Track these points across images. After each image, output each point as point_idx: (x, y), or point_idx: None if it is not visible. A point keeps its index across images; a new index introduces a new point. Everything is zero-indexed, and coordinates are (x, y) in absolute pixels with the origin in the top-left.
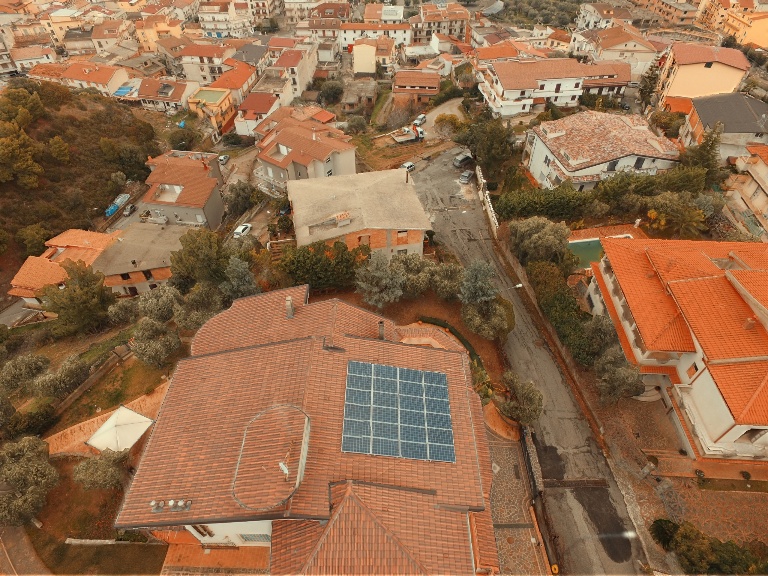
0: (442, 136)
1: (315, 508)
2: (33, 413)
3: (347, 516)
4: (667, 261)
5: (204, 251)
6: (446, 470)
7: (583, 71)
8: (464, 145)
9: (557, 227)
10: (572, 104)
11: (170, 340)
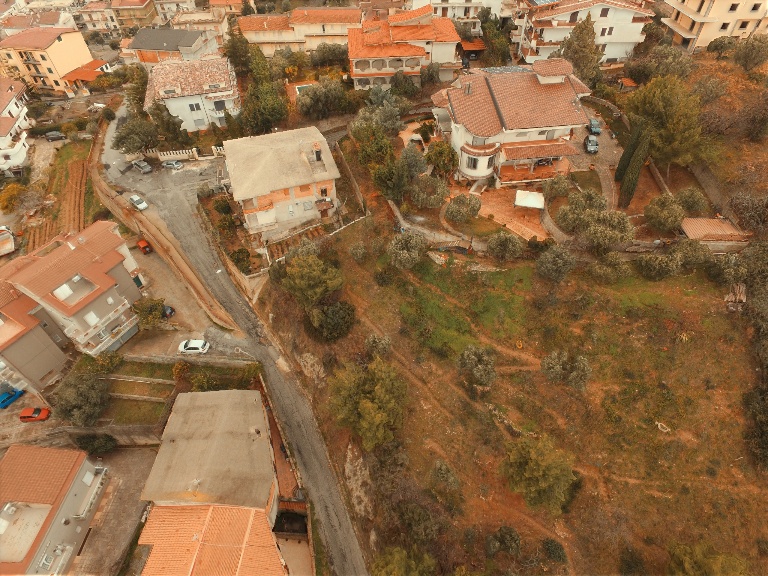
0: (34, 209)
1: None
2: (540, 241)
3: None
4: (375, 40)
5: (401, 161)
6: None
7: (4, 92)
8: (141, 148)
9: (323, 79)
10: (32, 123)
11: (462, 196)
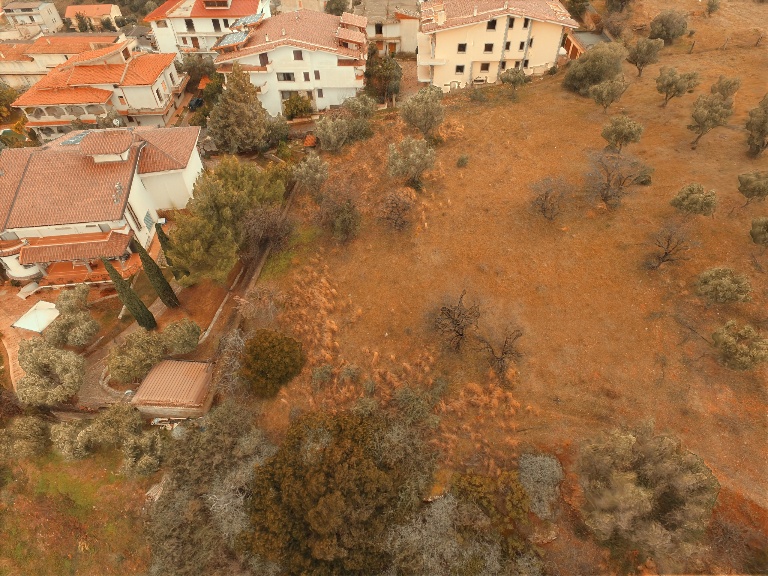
0: None
1: (139, 143)
2: None
3: (146, 136)
4: (51, 83)
5: None
6: (138, 129)
7: None
8: None
9: None
10: None
11: None
